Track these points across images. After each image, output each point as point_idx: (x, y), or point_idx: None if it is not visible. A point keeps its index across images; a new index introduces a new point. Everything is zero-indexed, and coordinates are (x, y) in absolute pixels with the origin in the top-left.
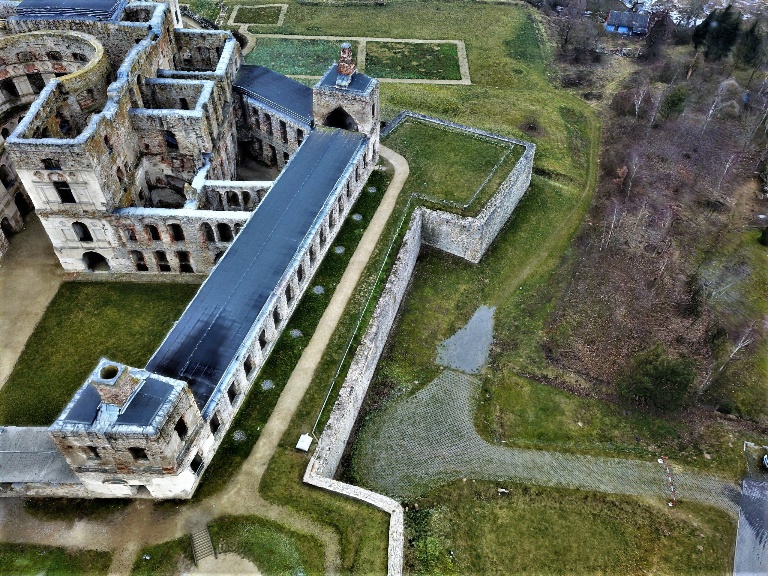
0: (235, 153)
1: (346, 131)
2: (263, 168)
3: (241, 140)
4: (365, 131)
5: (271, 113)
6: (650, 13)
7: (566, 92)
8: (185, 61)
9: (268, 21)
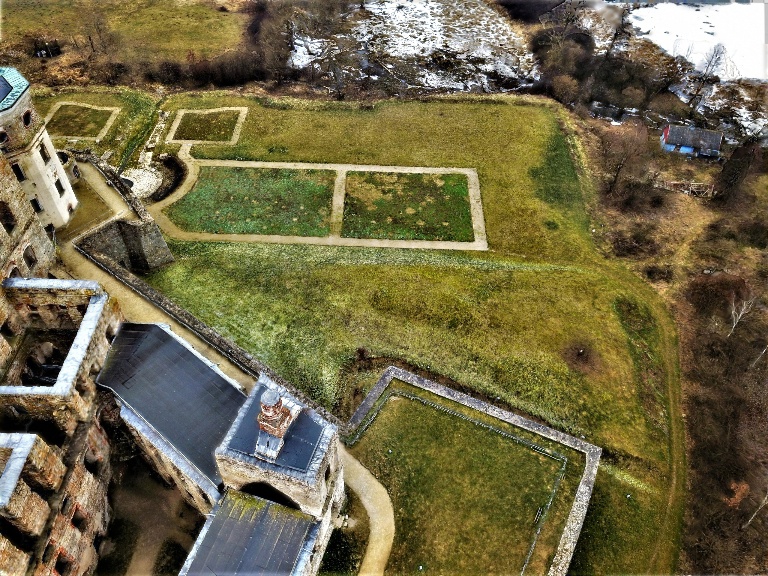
0: (105, 486)
1: (279, 509)
2: (159, 489)
3: (117, 460)
4: (312, 513)
5: (155, 447)
6: (712, 110)
7: (621, 265)
8: (33, 316)
9: (219, 136)
